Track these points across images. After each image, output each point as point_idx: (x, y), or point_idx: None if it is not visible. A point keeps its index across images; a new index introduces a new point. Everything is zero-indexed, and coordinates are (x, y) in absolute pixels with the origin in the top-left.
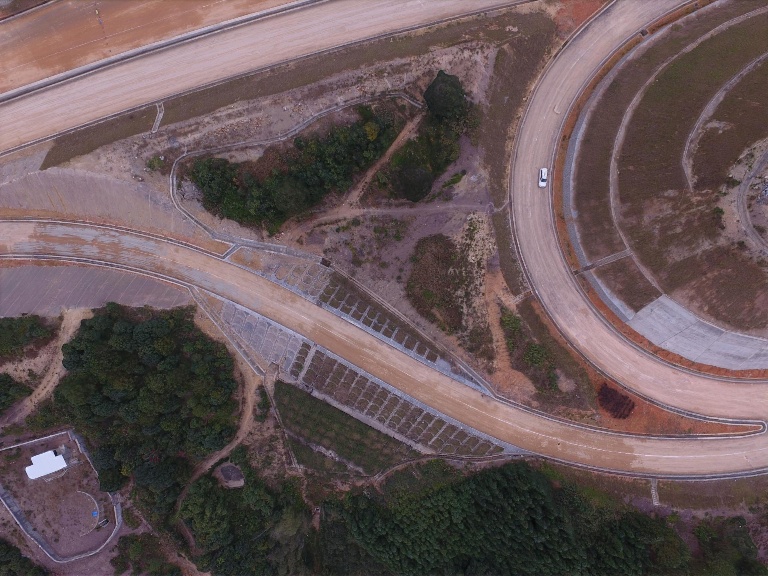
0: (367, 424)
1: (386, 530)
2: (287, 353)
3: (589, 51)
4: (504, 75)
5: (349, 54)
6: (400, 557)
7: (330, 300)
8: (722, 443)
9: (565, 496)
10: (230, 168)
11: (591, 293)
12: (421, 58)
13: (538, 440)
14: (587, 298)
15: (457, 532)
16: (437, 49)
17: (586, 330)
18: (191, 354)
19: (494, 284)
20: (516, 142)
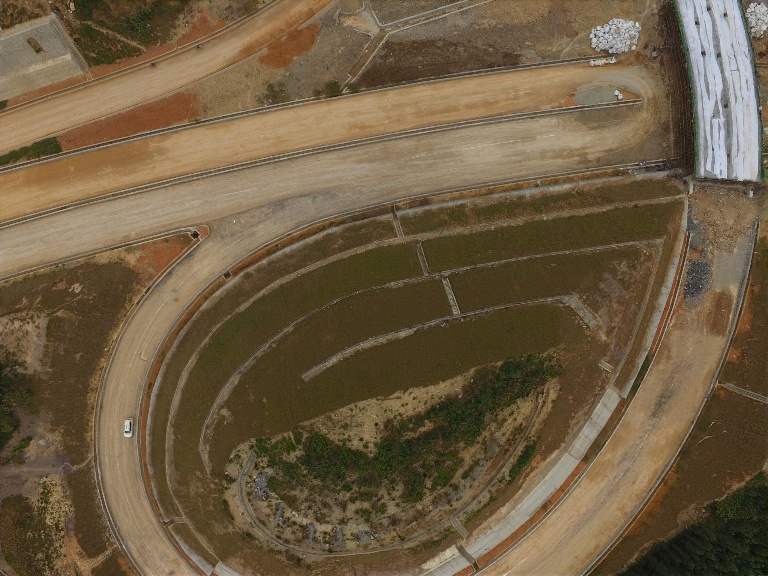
0: None
1: None
2: None
3: (174, 295)
4: (67, 337)
5: None
6: None
7: None
8: None
9: None
10: None
11: None
12: None
13: None
14: (177, 548)
15: None
16: None
17: None
18: None
19: (71, 548)
20: (100, 393)
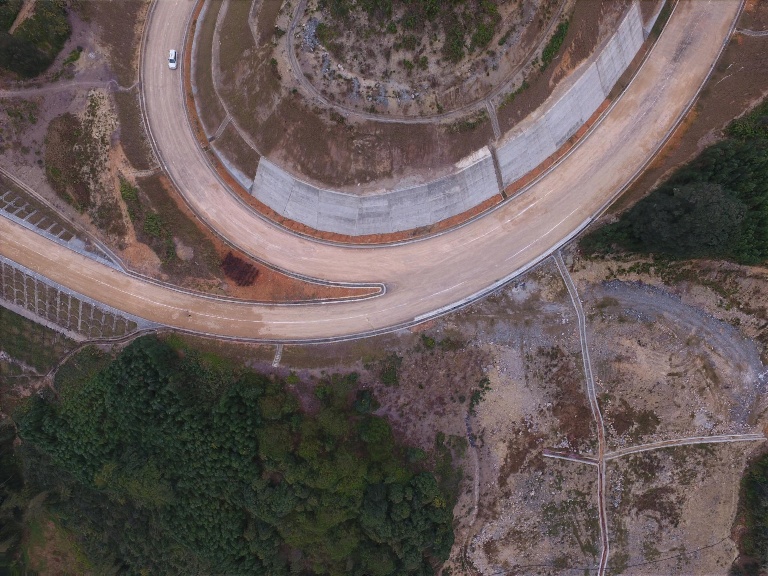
0: (20, 314)
1: (53, 427)
2: None
3: None
4: None
5: None
6: (70, 455)
7: None
8: (346, 307)
9: (185, 362)
10: None
11: (219, 168)
12: None
13: (169, 313)
14: (217, 173)
15: (111, 418)
16: None
17: (216, 204)
18: None
19: (116, 158)
20: (146, 26)
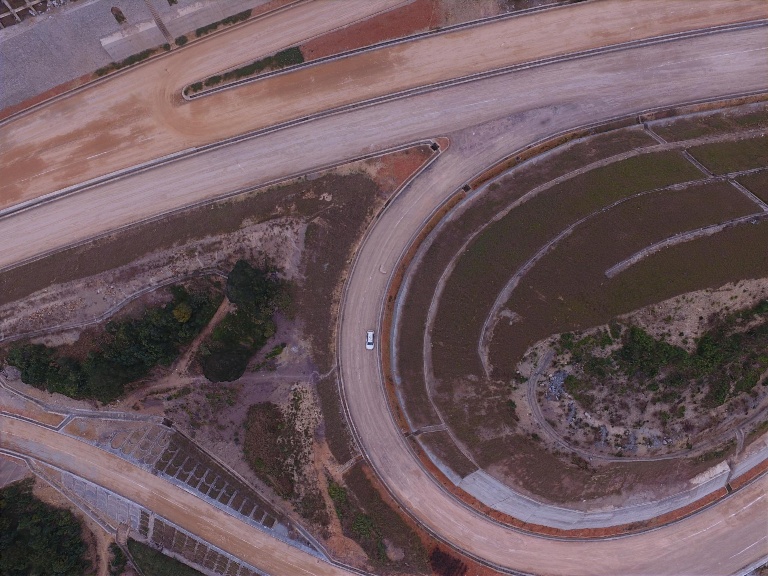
0: None
1: None
2: (131, 517)
3: (413, 209)
4: (319, 246)
5: (170, 223)
6: None
7: (167, 467)
8: None
9: None
10: (45, 354)
11: (422, 455)
12: (231, 236)
13: None
14: (418, 460)
15: None
16: (248, 225)
17: (419, 492)
18: (30, 527)
19: (321, 454)
20: (342, 305)
